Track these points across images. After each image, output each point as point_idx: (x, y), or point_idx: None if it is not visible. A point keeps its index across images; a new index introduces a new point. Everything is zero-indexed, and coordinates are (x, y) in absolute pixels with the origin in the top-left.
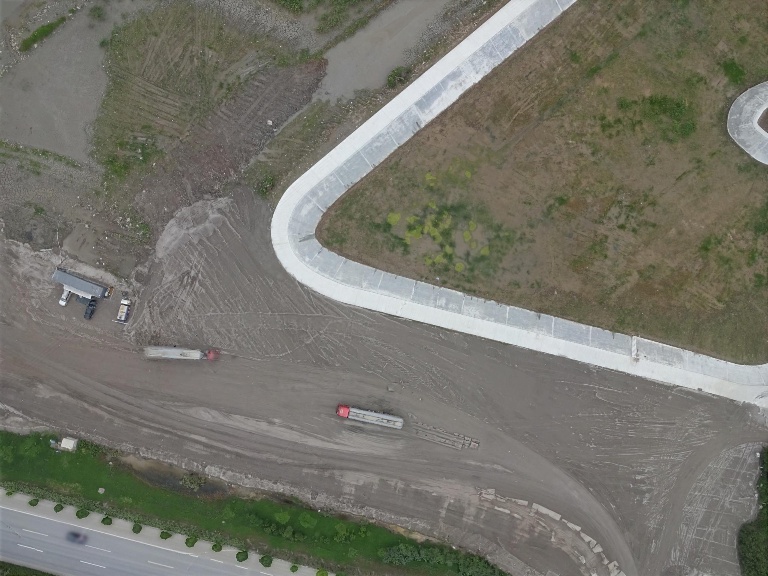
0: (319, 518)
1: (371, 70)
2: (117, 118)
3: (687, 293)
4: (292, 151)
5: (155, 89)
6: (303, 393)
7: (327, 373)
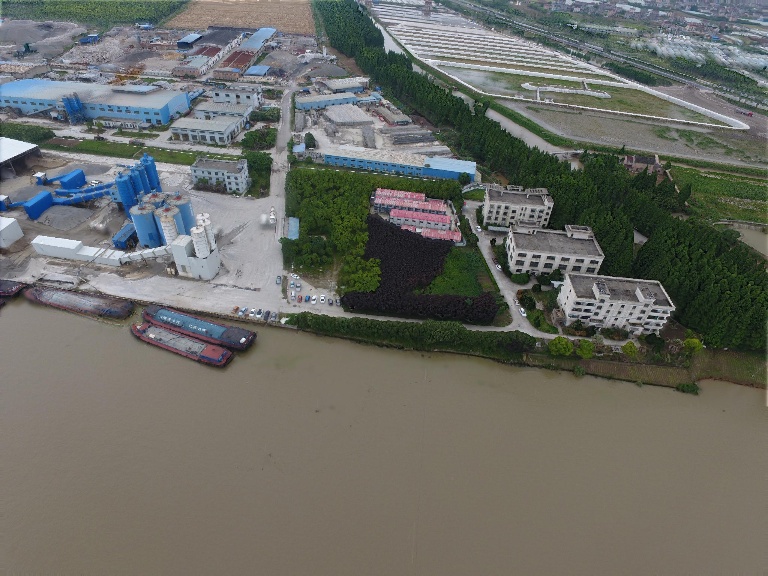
0: (767, 116)
1: (695, 128)
2: None
3: None
4: (731, 131)
5: (767, 148)
6: (759, 120)
7: None
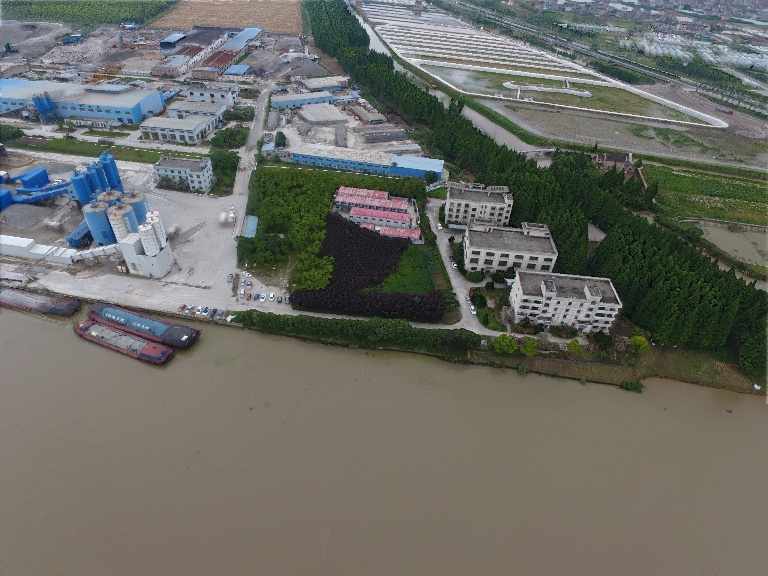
0: None
1: None
2: (760, 149)
3: (627, 95)
4: (709, 129)
5: None
6: None
7: (730, 117)
